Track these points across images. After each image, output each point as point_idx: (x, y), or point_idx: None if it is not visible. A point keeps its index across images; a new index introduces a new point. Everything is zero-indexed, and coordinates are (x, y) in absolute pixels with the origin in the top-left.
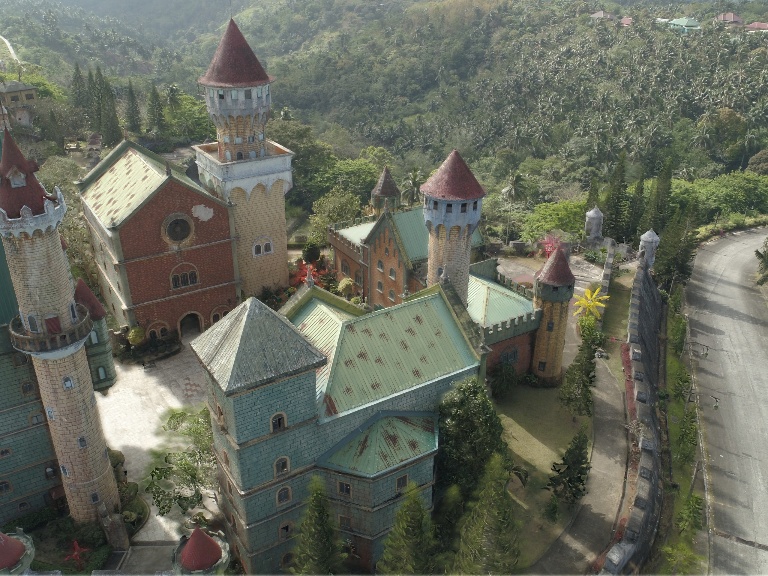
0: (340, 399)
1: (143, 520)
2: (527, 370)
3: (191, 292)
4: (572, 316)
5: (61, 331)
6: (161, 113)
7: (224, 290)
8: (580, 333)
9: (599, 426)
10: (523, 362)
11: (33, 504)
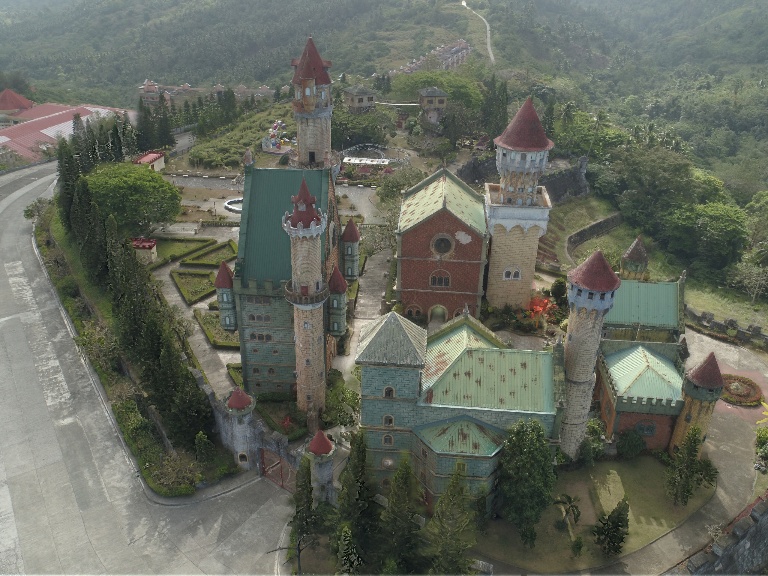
0: (438, 395)
1: (334, 424)
2: (665, 448)
3: (443, 291)
4: (767, 424)
5: (308, 295)
6: (552, 125)
7: (468, 297)
8: (756, 441)
9: (696, 519)
10: (661, 439)
11: (284, 388)
